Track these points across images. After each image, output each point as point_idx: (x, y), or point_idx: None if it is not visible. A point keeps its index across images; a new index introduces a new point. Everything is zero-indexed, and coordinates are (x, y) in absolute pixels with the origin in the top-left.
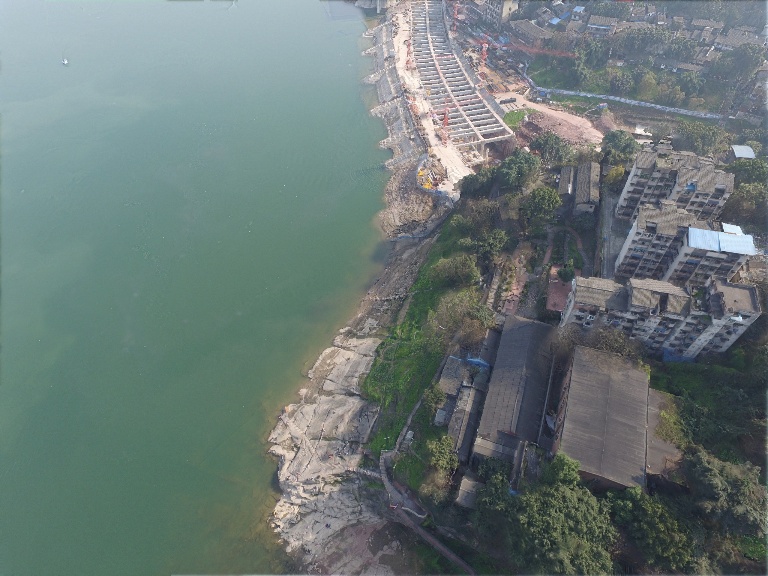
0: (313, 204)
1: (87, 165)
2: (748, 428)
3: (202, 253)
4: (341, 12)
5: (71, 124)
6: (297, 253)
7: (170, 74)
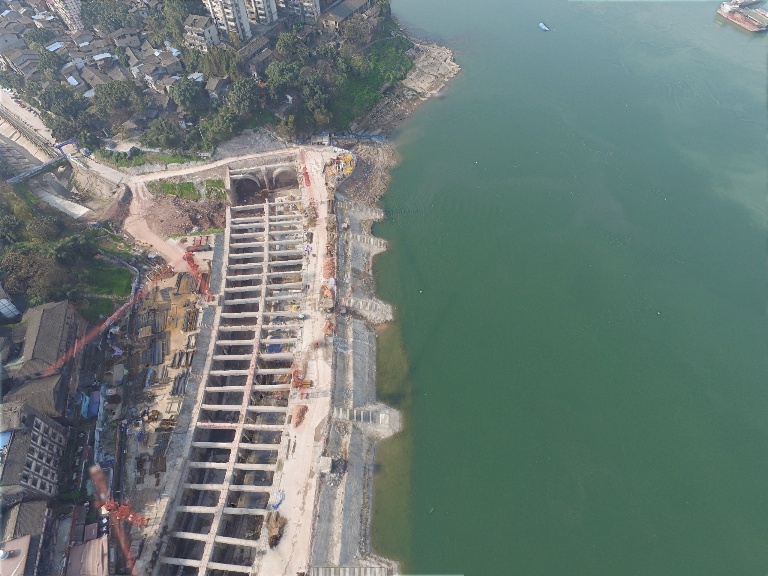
0: (460, 179)
1: None
2: None
3: (548, 147)
4: None
5: None
6: (466, 141)
7: None
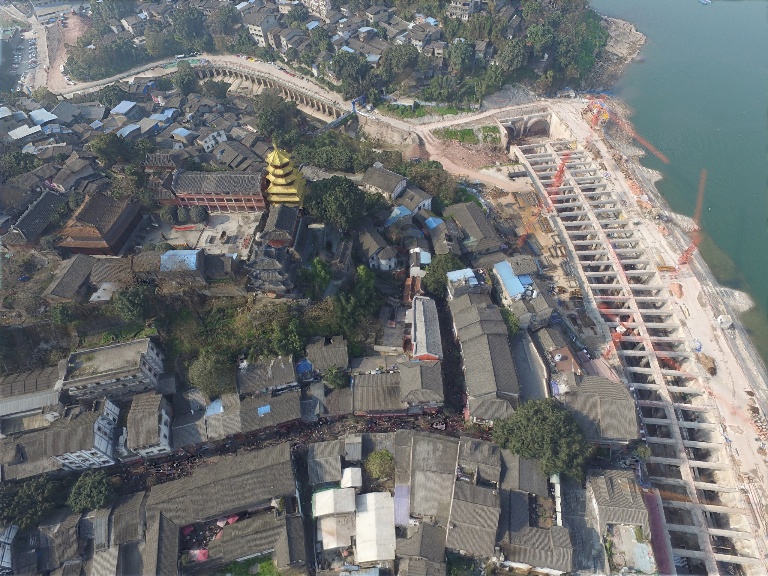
0: (697, 124)
1: None
2: None
3: (764, 96)
4: None
5: None
6: (685, 94)
7: None
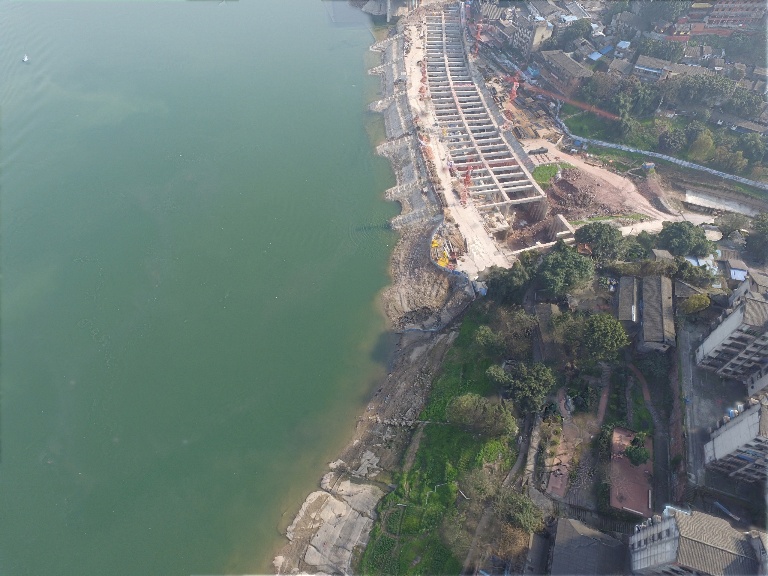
0: (304, 273)
1: (34, 200)
2: None
3: (164, 335)
4: (346, 17)
5: (23, 141)
6: (281, 343)
7: (146, 83)
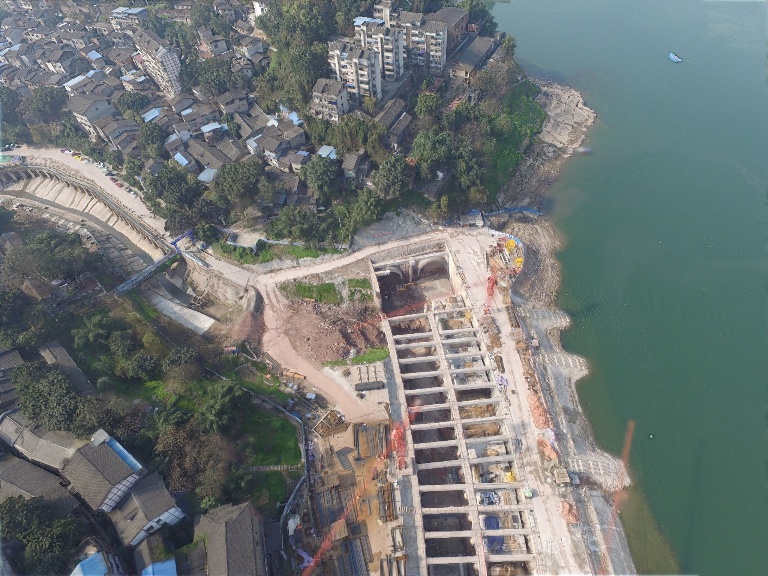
0: (647, 266)
1: None
2: (401, 5)
3: (740, 218)
4: None
5: None
6: (636, 211)
7: None
